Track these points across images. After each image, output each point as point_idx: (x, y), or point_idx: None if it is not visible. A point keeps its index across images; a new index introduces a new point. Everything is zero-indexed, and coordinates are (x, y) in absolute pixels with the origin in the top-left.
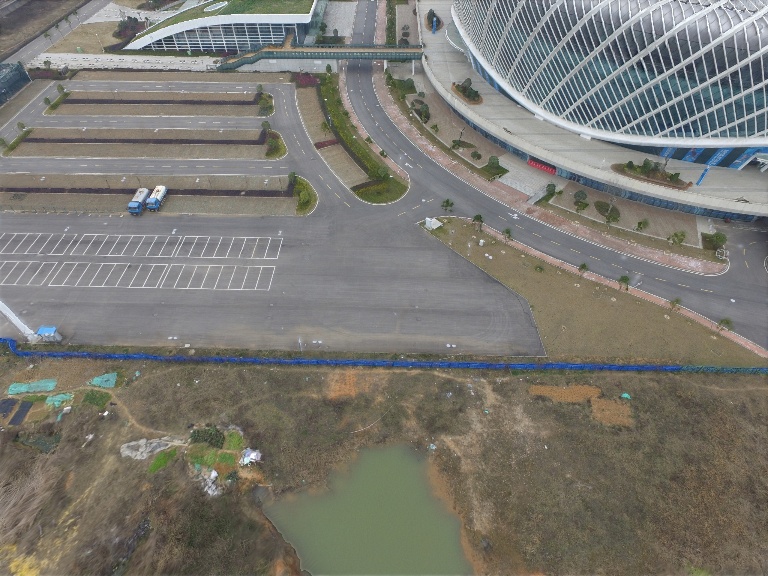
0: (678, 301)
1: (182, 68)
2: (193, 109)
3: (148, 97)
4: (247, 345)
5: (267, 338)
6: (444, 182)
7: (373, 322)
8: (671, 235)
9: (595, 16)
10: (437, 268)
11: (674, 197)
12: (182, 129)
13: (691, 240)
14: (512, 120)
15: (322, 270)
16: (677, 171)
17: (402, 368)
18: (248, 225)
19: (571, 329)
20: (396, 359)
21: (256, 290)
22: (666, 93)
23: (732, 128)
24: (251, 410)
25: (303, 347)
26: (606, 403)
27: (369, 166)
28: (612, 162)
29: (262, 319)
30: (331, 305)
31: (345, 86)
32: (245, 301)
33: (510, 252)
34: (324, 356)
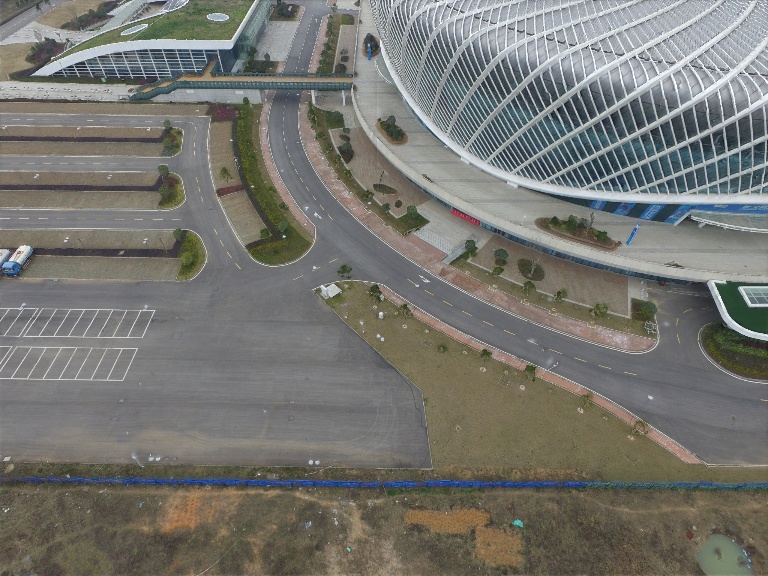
0: (596, 388)
1: (92, 98)
2: (91, 147)
3: (44, 133)
4: (79, 457)
5: (106, 447)
6: (353, 237)
7: (236, 423)
8: (598, 301)
9: (503, 62)
10: (325, 349)
11: (601, 259)
12: (73, 172)
13: (619, 308)
14: (435, 164)
15: (191, 353)
16: (607, 227)
17: (258, 488)
18: (118, 294)
19: (466, 430)
20: (253, 475)
21: (108, 380)
22: (586, 146)
23: (661, 185)
24: (63, 551)
25: (146, 459)
26: (493, 534)
27: (271, 218)
28: (537, 216)
29: (106, 420)
30: (192, 400)
31: (267, 119)
32: (91, 396)
33: (413, 326)
34: (168, 472)
